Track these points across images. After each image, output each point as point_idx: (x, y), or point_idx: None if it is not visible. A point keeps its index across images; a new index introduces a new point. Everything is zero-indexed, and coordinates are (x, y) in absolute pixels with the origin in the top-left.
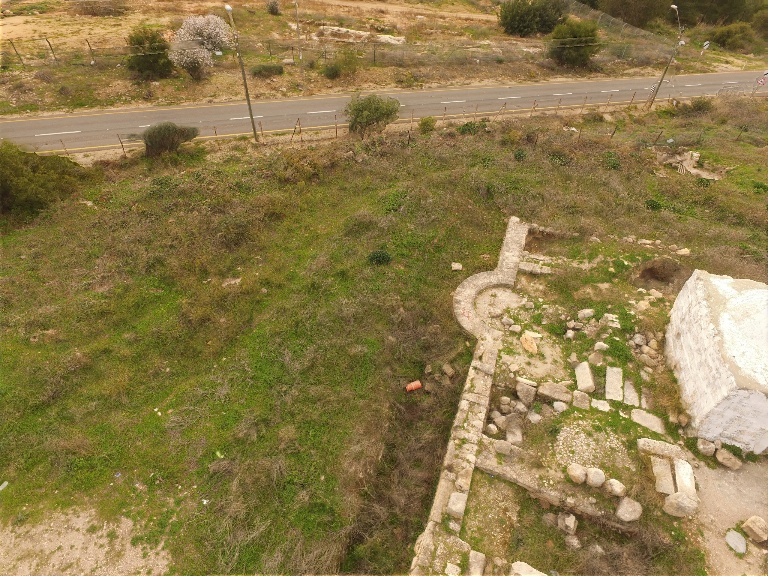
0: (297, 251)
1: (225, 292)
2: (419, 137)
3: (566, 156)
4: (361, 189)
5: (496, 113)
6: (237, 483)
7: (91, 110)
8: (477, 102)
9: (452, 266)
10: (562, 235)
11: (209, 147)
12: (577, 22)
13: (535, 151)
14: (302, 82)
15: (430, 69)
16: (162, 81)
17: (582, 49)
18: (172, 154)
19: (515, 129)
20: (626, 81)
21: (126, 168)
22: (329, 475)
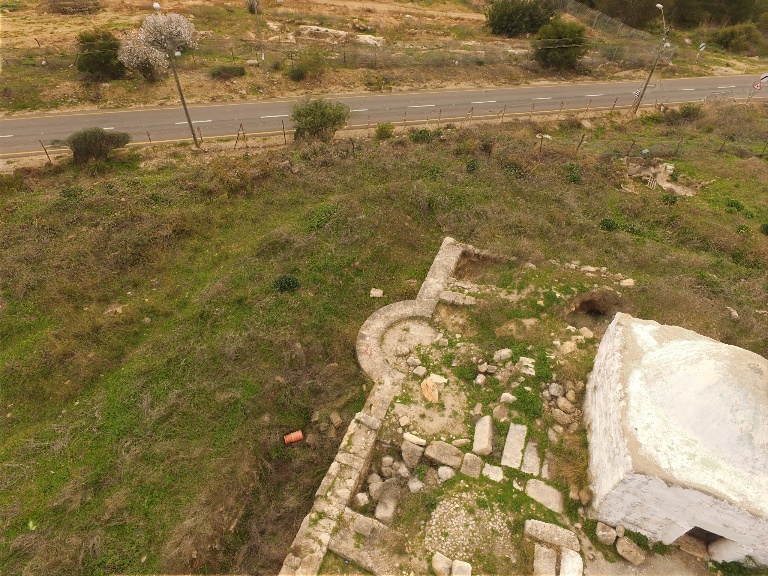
0: (199, 273)
1: (97, 323)
2: (367, 145)
3: (522, 168)
4: (289, 203)
5: None
6: (28, 569)
7: (32, 113)
8: (447, 107)
9: (371, 293)
10: (499, 259)
11: (145, 154)
12: (562, 22)
13: (490, 162)
14: (264, 84)
15: (404, 71)
16: (113, 82)
17: (567, 51)
18: (99, 161)
19: (473, 137)
20: (614, 85)
21: (50, 176)
22: (152, 556)
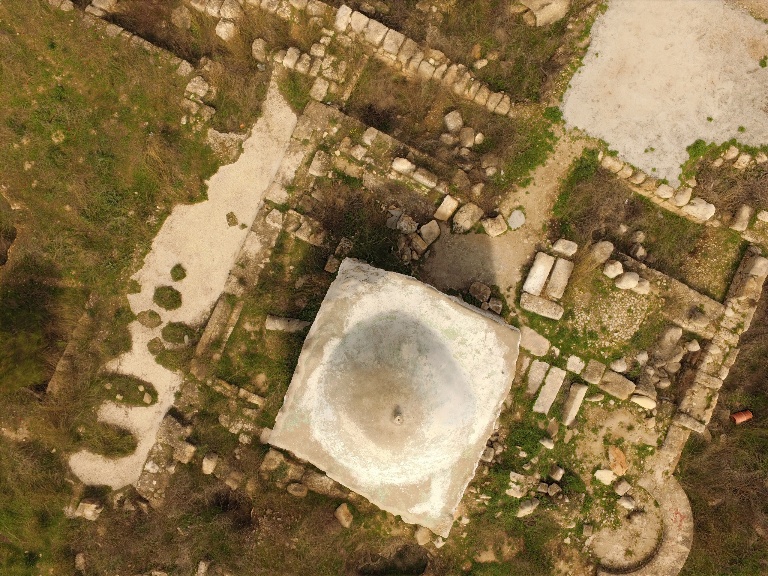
0: None
1: None
2: None
3: None
4: None
5: None
6: None
7: None
8: None
9: None
10: None
11: None
12: None
13: None
14: None
15: None
16: None
17: None
18: None
19: None
20: None
21: None
22: None
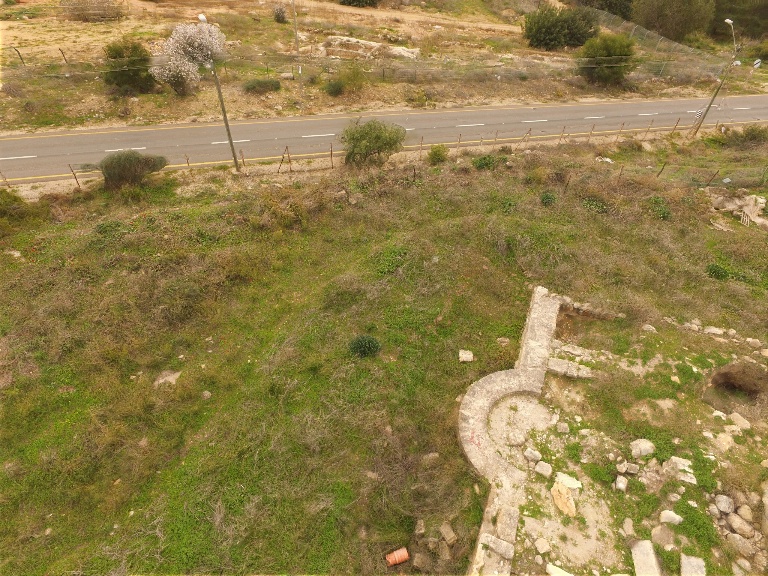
0: (260, 331)
1: (150, 401)
2: (427, 172)
3: (604, 201)
4: (351, 241)
5: (519, 140)
6: None
7: (56, 130)
8: (497, 126)
9: (460, 356)
10: (603, 315)
11: (181, 178)
12: (612, 36)
13: (566, 193)
14: (301, 99)
15: (445, 86)
16: (142, 97)
17: None
18: (134, 188)
19: (542, 164)
20: (665, 103)
21: (79, 203)
22: None
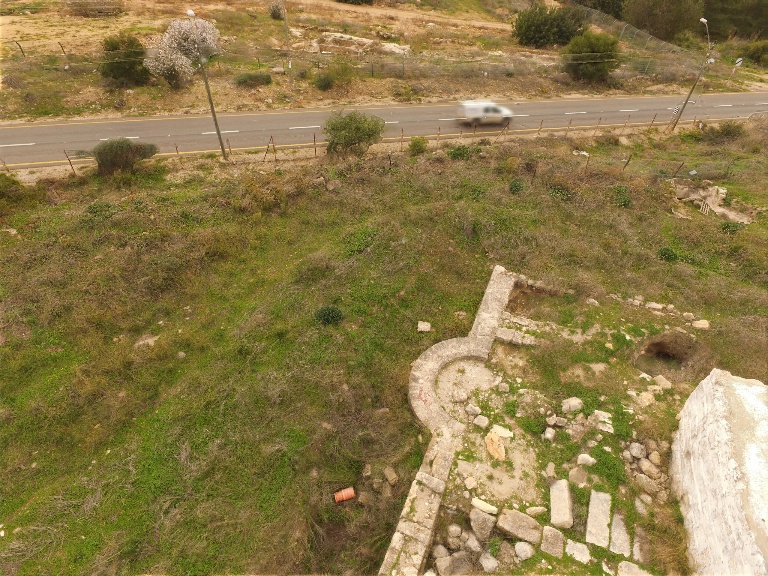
0: (235, 301)
1: (129, 358)
2: (404, 162)
3: (569, 190)
4: (326, 224)
5: (498, 133)
6: None
7: (54, 119)
8: (479, 120)
9: (418, 326)
10: (554, 292)
11: (171, 165)
12: (596, 34)
13: (534, 182)
14: (290, 93)
15: (432, 82)
16: (137, 89)
17: (600, 63)
18: (125, 173)
19: (514, 155)
20: (648, 99)
21: (73, 188)
22: None
